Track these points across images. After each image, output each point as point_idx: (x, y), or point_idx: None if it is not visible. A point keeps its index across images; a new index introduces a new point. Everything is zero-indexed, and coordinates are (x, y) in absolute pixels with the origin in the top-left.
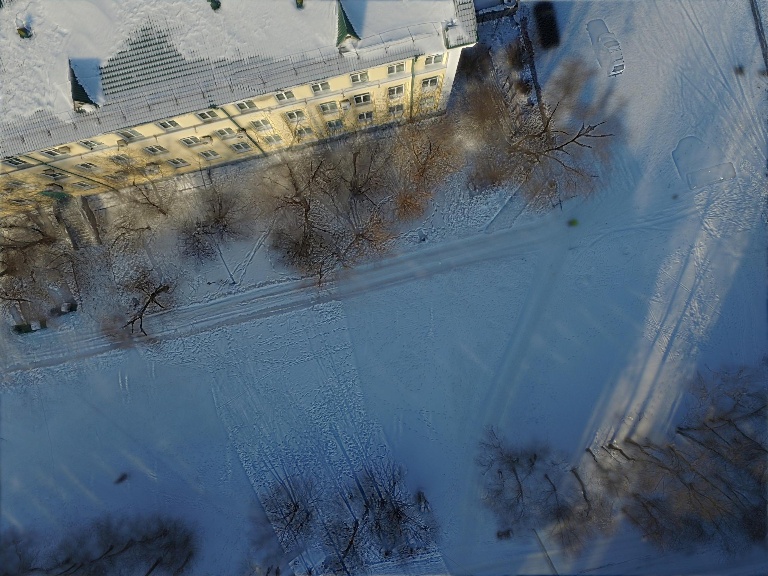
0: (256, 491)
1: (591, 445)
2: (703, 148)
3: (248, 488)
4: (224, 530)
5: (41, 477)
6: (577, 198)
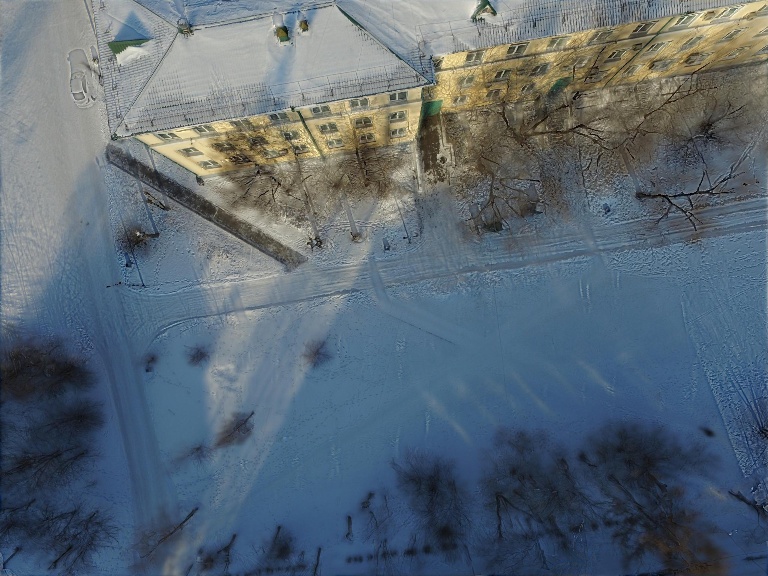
0: (721, 412)
1: None
2: None
3: (712, 408)
4: (683, 450)
5: (491, 384)
6: None
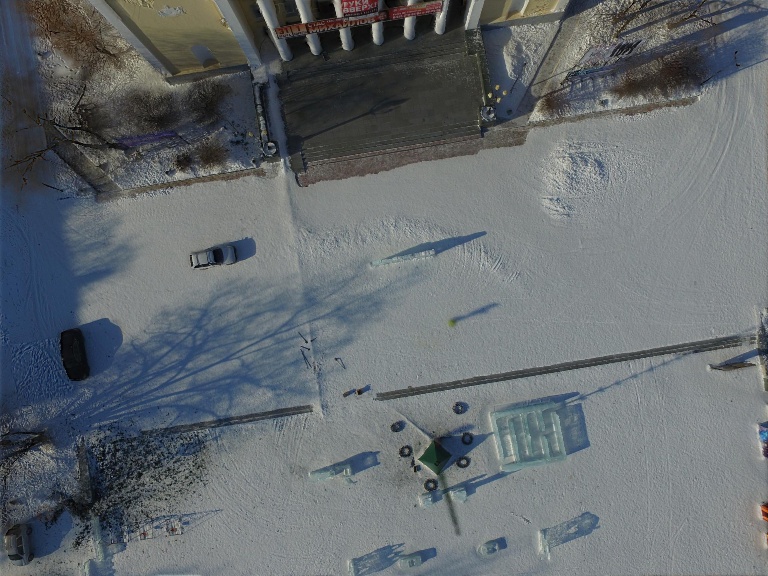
0: None
1: None
2: (109, 351)
3: None
4: None
5: None
6: (69, 216)
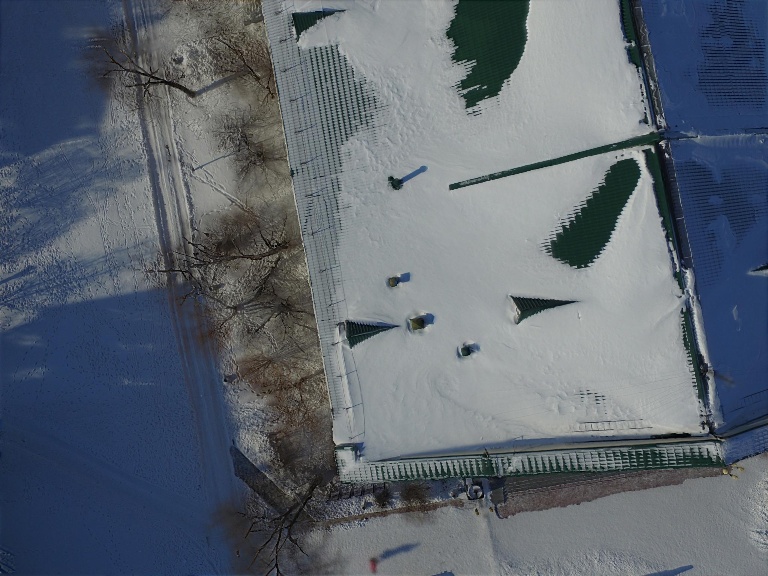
0: None
1: None
2: None
3: None
4: None
5: None
6: None
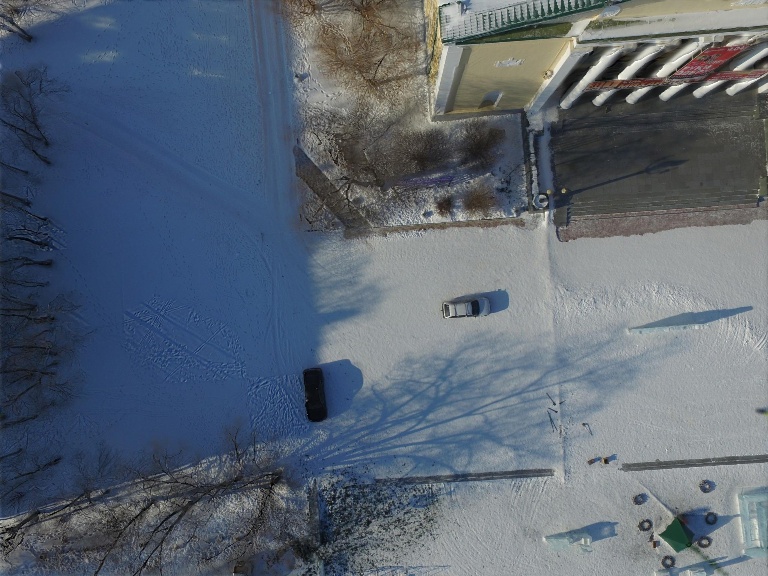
0: None
1: (50, 223)
2: (348, 394)
3: None
4: None
5: None
6: (316, 250)
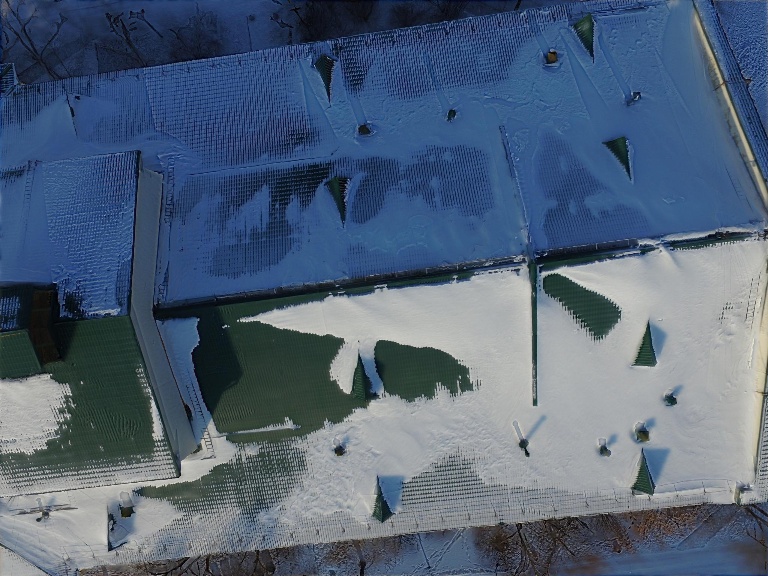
0: None
1: None
2: None
3: None
4: None
5: None
6: None
